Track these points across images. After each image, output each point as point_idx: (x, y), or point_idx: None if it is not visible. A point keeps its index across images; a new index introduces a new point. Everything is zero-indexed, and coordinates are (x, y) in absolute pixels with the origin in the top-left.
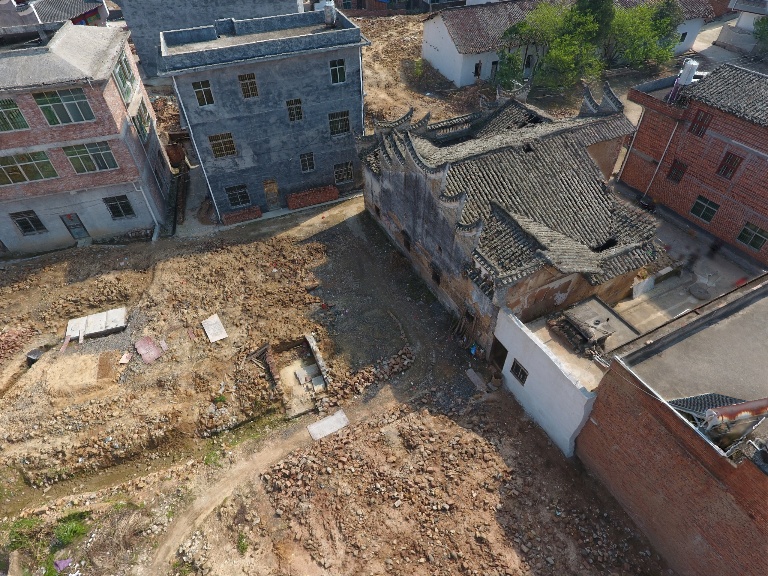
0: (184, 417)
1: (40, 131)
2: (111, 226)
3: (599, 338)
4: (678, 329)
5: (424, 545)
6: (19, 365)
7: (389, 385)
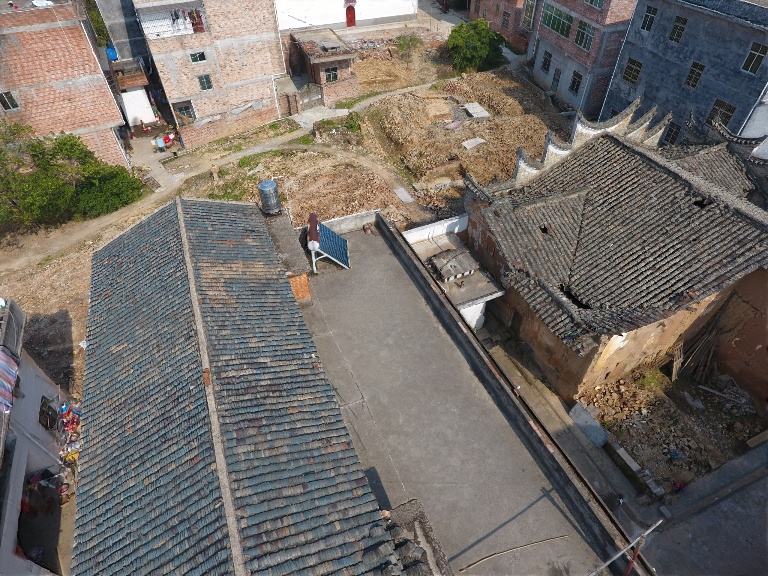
0: (410, 145)
1: (580, 3)
2: (566, 93)
3: (435, 264)
4: (405, 250)
5: (321, 217)
6: (443, 97)
7: (434, 219)
